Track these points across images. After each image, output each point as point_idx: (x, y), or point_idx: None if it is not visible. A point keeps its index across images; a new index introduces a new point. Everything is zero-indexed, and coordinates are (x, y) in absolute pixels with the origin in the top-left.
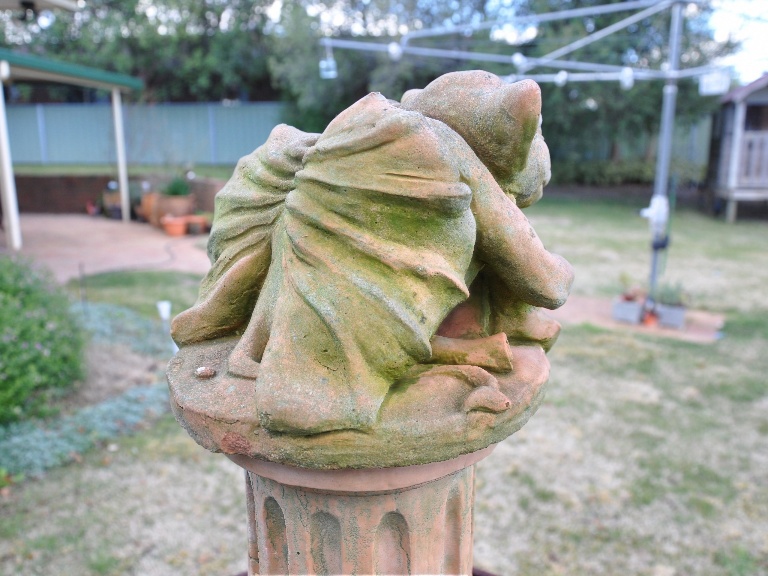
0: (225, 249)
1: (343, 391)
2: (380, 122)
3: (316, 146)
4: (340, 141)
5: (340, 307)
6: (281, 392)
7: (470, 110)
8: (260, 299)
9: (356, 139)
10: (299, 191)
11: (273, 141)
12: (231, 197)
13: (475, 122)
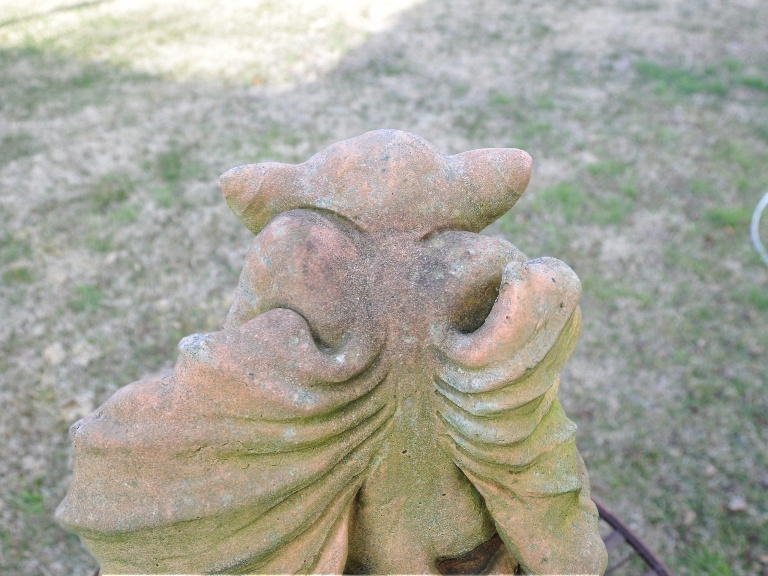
0: (283, 557)
1: (581, 515)
2: (570, 299)
3: (524, 367)
4: (548, 344)
5: (570, 469)
6: (588, 570)
7: (466, 201)
8: (390, 546)
9: (560, 331)
10: (507, 420)
11: (256, 383)
12: (258, 500)
13: (476, 211)
